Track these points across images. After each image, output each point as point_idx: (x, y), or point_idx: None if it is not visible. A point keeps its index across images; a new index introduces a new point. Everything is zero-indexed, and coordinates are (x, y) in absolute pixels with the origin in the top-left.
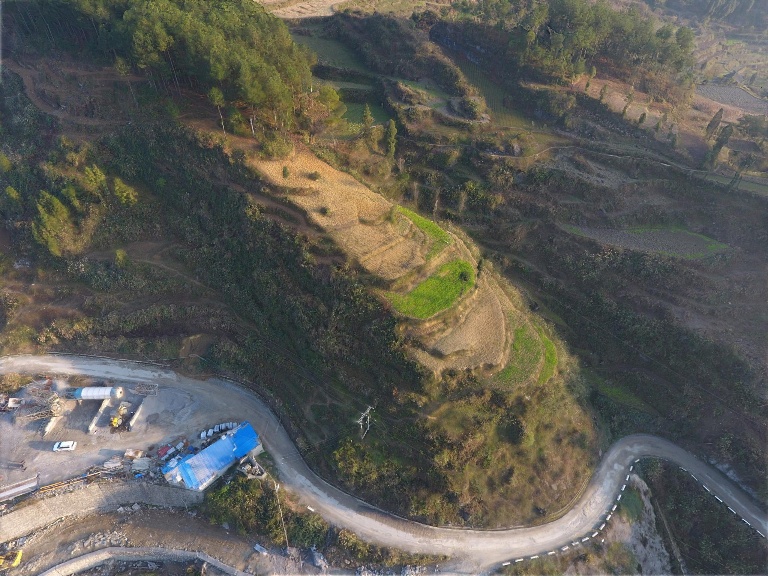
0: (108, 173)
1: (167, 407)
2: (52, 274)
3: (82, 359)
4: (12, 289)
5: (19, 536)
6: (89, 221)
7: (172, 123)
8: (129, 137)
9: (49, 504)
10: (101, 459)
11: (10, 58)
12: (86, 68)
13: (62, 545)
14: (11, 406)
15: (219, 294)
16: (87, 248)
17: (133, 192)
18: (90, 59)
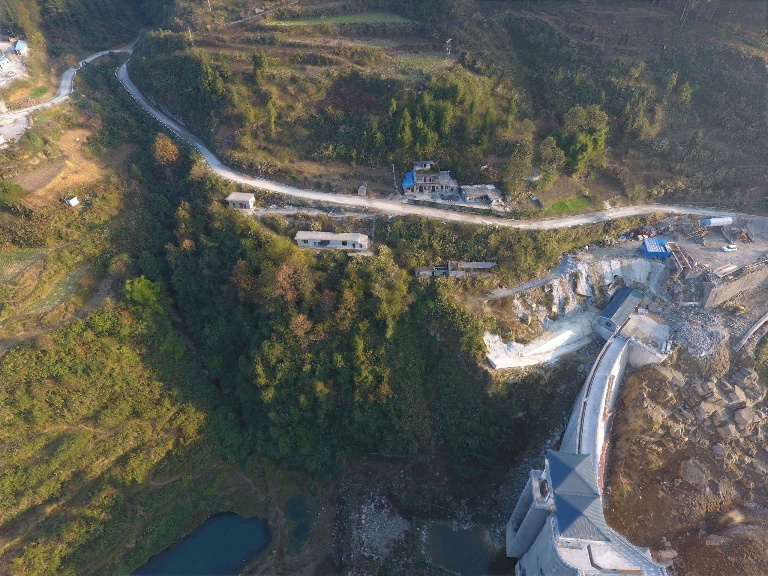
0: (652, 83)
1: (761, 230)
2: (638, 152)
3: (679, 206)
4: (611, 164)
5: (726, 300)
6: (660, 114)
7: (714, 43)
8: (670, 56)
9: (747, 278)
10: (758, 254)
11: (510, 9)
12: (615, 10)
13: (758, 303)
14: (670, 230)
15: (761, 160)
16: (655, 134)
17: (689, 93)
18: (618, 3)
